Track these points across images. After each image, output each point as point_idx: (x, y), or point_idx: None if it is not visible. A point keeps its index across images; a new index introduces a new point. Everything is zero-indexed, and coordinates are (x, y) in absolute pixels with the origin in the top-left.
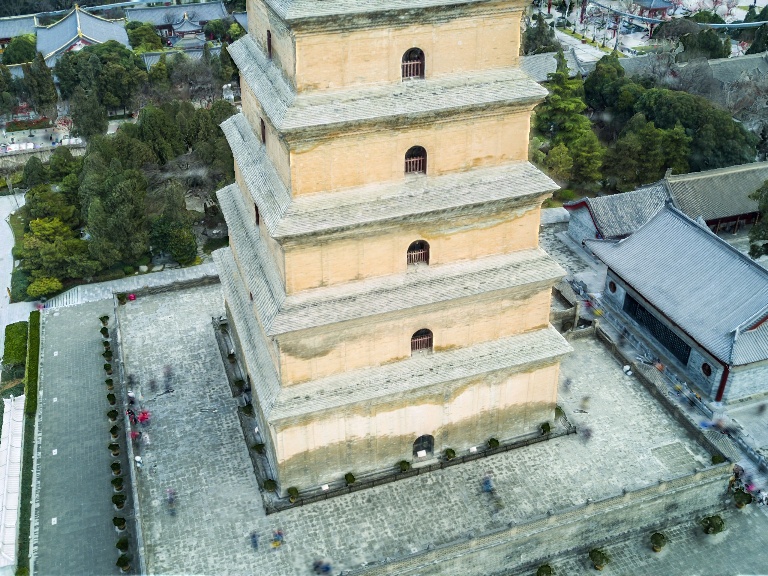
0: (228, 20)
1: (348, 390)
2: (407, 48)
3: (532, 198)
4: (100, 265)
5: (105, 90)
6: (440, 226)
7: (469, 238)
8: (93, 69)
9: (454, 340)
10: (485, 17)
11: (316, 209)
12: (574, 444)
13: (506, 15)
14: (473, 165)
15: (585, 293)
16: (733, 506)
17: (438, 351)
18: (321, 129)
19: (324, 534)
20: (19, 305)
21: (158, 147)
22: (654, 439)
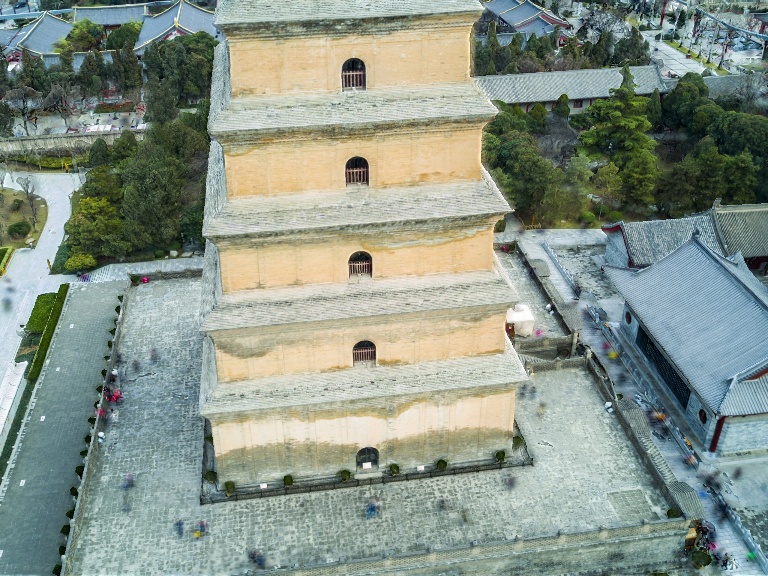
0: None
1: (284, 393)
2: (346, 58)
3: (482, 219)
4: (131, 246)
5: (187, 79)
6: (383, 239)
7: (415, 254)
8: (178, 58)
9: (399, 355)
10: (430, 31)
11: (251, 212)
12: (527, 476)
13: (453, 30)
14: (420, 180)
15: (600, 321)
16: (691, 565)
17: (382, 365)
18: (253, 134)
19: (248, 531)
20: (57, 277)
21: None
22: (614, 483)
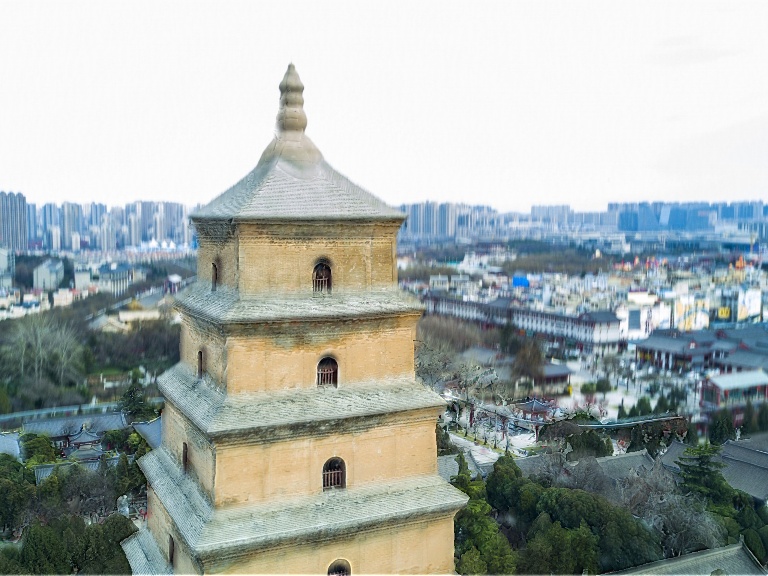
0: (127, 430)
1: None
2: (328, 457)
3: None
4: None
5: None
6: None
7: None
8: None
9: None
10: (402, 426)
11: None
12: None
13: (422, 424)
14: None
15: None
16: None
17: None
18: (239, 545)
19: None
20: None
21: (39, 568)
22: None
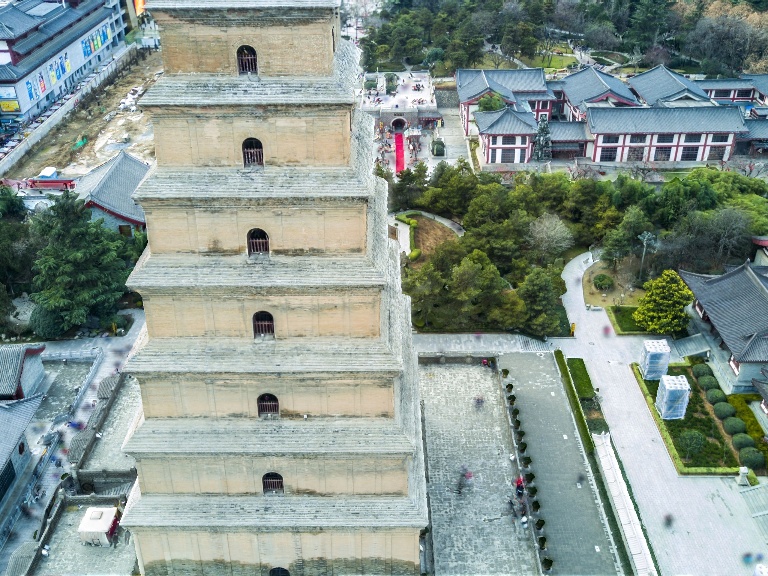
0: None
1: None
2: None
3: None
4: None
5: None
6: None
7: None
8: None
9: None
10: None
11: None
12: None
13: None
14: None
15: None
16: None
17: None
18: None
19: None
20: None
21: None
22: None
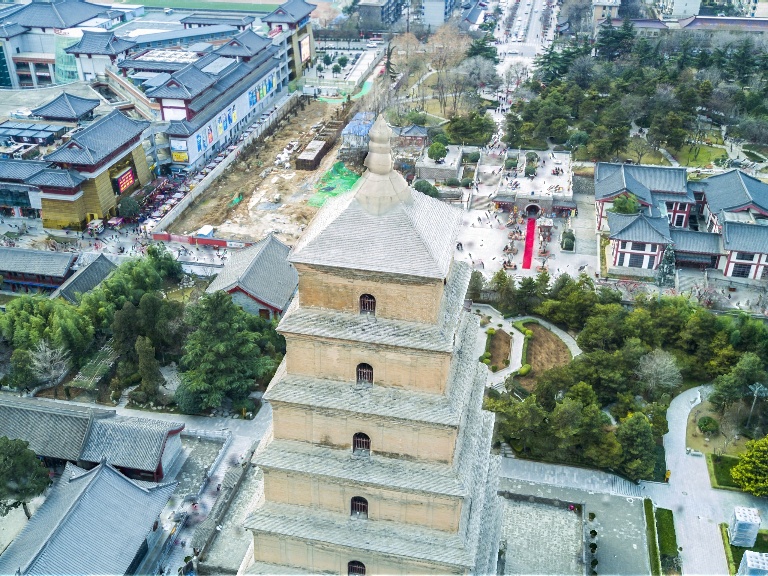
0: None
1: None
2: None
3: None
4: None
5: None
6: None
7: None
8: None
9: None
10: None
11: None
12: None
13: None
14: None
15: None
16: None
17: None
18: None
19: None
20: None
21: None
22: None
